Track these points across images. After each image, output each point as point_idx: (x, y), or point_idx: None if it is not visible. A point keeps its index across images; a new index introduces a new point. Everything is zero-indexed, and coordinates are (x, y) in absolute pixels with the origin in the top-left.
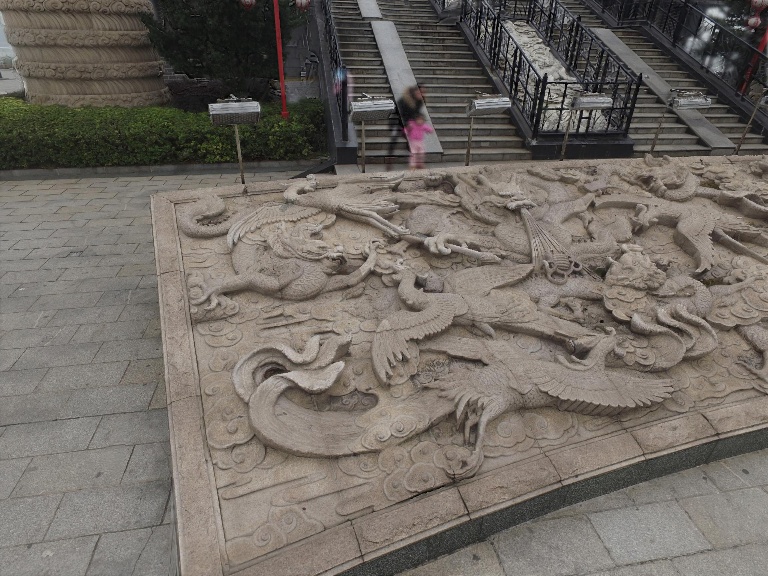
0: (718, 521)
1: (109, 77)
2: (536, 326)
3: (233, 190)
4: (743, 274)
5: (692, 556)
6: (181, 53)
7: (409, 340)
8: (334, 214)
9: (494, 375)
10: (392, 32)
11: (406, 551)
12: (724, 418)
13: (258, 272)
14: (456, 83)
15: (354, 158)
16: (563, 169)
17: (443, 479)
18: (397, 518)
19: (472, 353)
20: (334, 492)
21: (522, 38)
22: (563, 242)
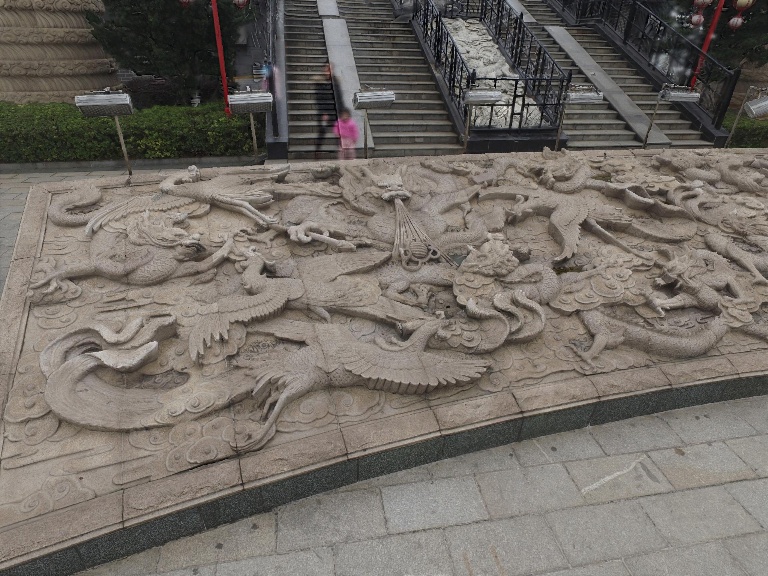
0: (506, 494)
1: (55, 74)
2: (370, 310)
3: (115, 181)
4: (601, 262)
5: (466, 526)
6: (128, 50)
7: (235, 322)
8: (208, 204)
9: (305, 355)
10: (342, 30)
11: (175, 518)
12: (532, 397)
13: (108, 258)
14: (400, 80)
15: (284, 153)
16: (456, 162)
17: (227, 451)
18: (167, 487)
19: (298, 335)
20: (116, 463)
21: (471, 36)
22: (432, 231)
